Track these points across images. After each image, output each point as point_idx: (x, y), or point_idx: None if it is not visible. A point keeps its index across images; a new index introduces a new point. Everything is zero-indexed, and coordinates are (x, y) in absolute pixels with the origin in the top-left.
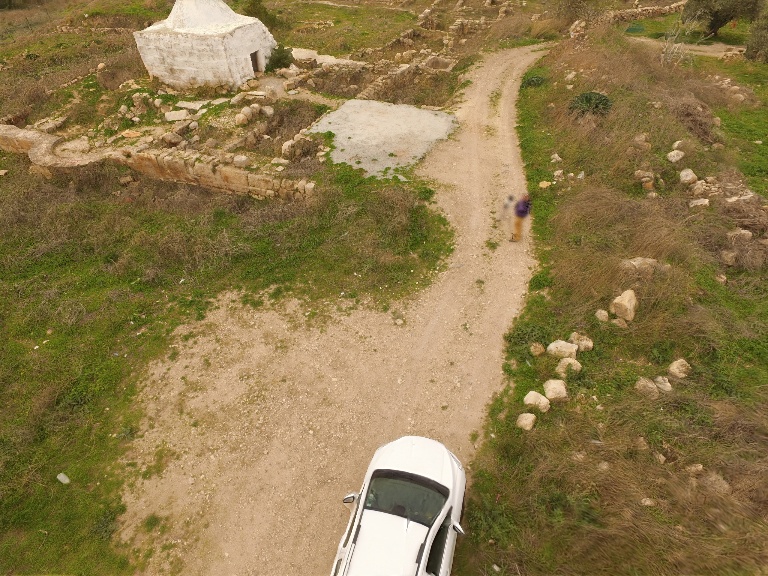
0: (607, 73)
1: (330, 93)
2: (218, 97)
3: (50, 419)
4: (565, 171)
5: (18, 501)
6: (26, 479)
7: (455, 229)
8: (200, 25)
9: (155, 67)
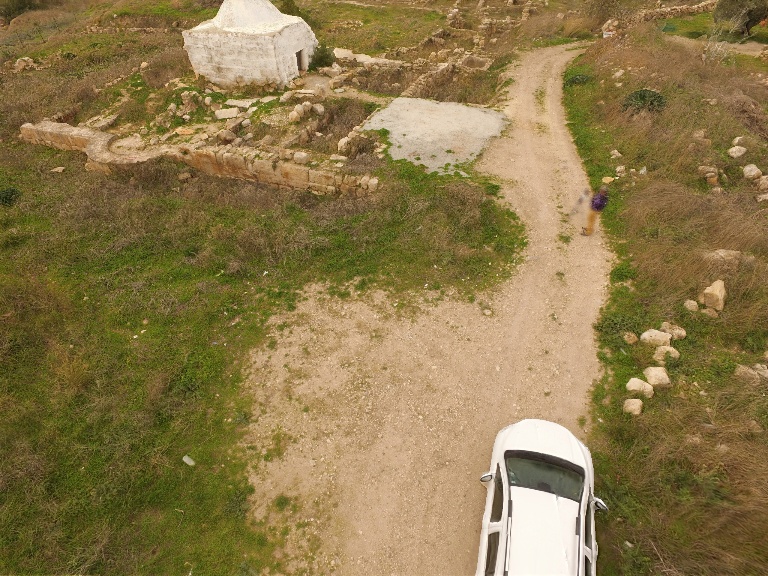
0: (657, 71)
1: (376, 91)
2: (266, 95)
3: (166, 404)
4: (627, 167)
5: (150, 482)
6: (154, 461)
7: (525, 223)
8: (249, 24)
9: (202, 66)
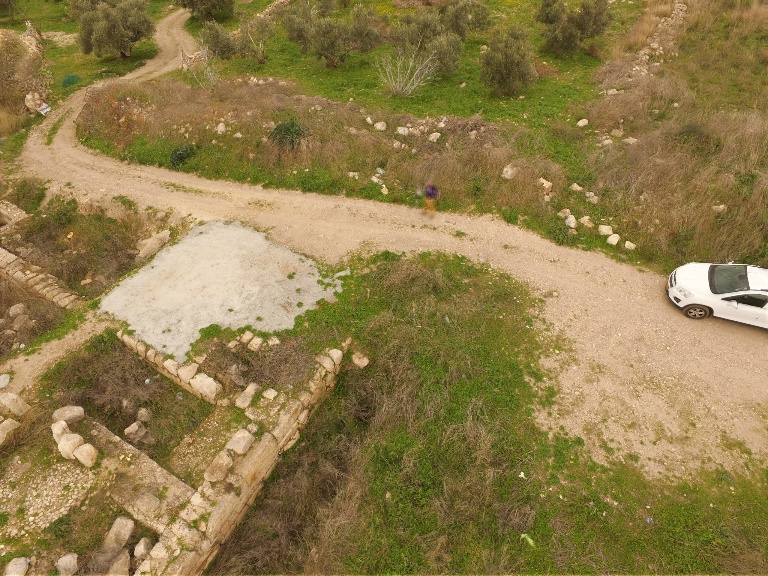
0: (251, 109)
1: (41, 332)
2: None
3: None
4: None
5: None
6: None
7: (436, 250)
8: None
9: None
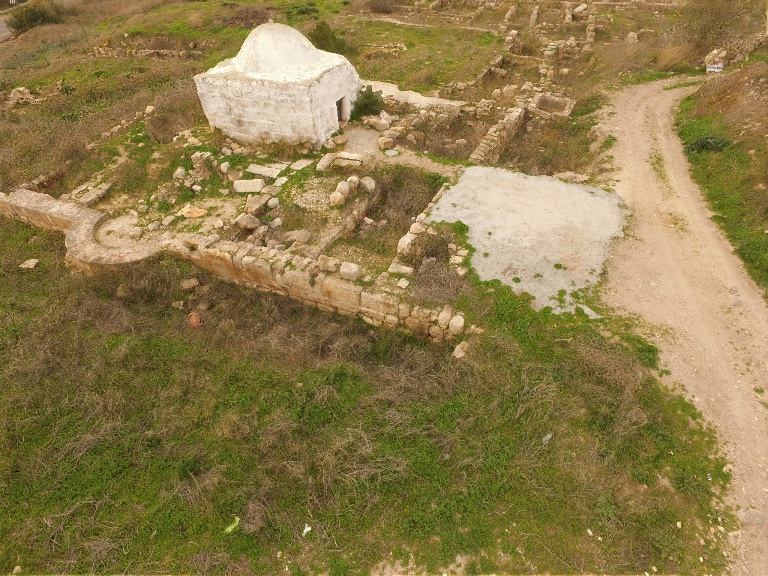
0: None
1: (438, 154)
2: (298, 158)
3: None
4: None
5: None
6: None
7: (714, 427)
8: (278, 68)
9: (218, 117)
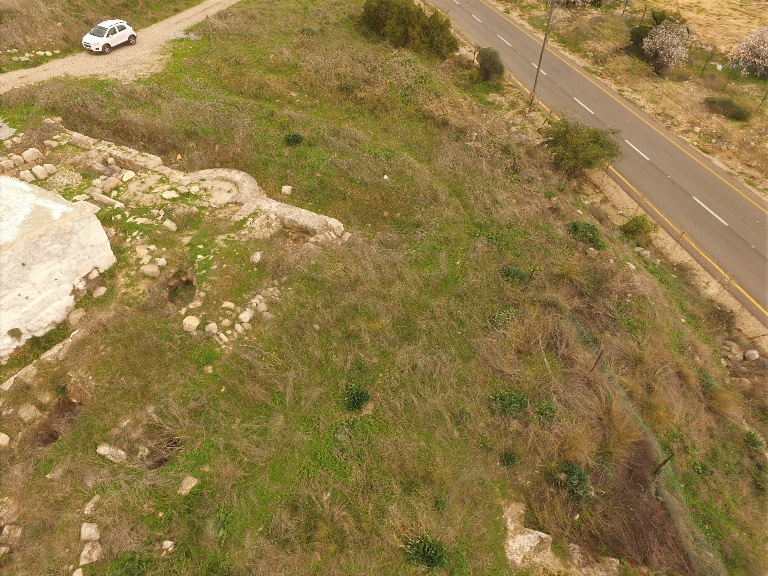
0: None
1: None
2: None
3: None
4: None
5: None
6: None
7: None
8: None
9: None
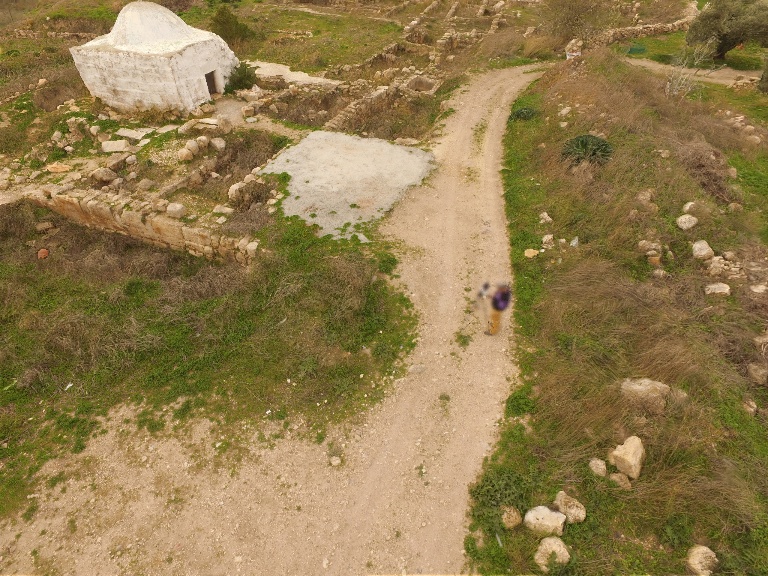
0: (606, 111)
1: (294, 121)
2: (166, 124)
3: None
4: (556, 236)
5: None
6: None
7: (420, 314)
8: (145, 42)
9: (97, 87)
